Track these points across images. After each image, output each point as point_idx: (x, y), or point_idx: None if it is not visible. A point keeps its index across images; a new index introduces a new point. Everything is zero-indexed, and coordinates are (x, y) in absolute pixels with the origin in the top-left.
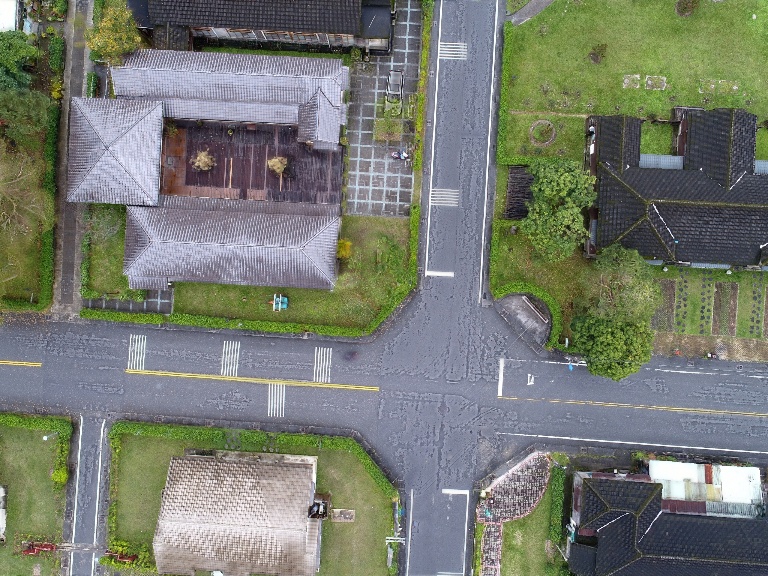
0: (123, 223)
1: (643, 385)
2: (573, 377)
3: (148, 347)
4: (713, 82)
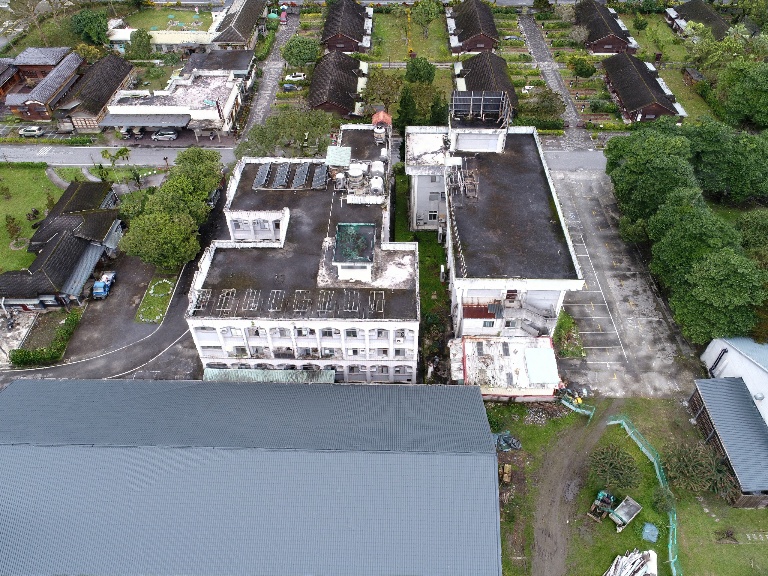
0: None
1: None
2: None
3: None
4: None
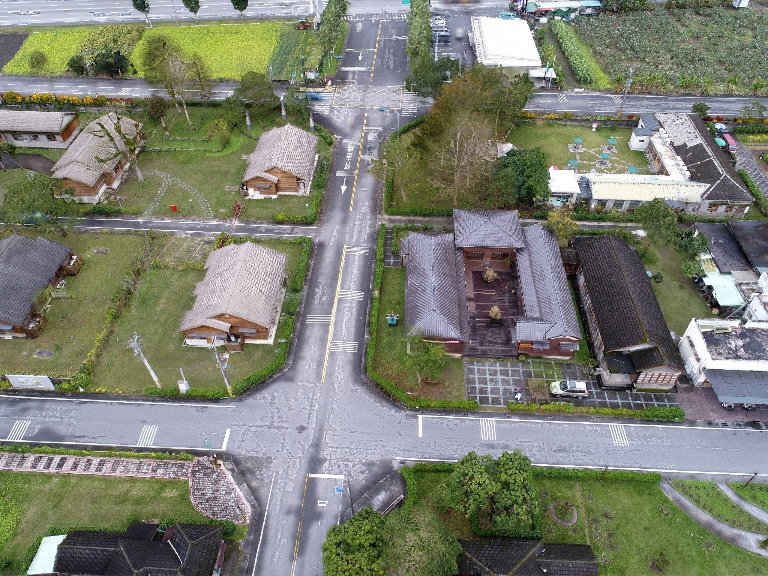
0: None
1: None
2: None
3: (361, 255)
4: None
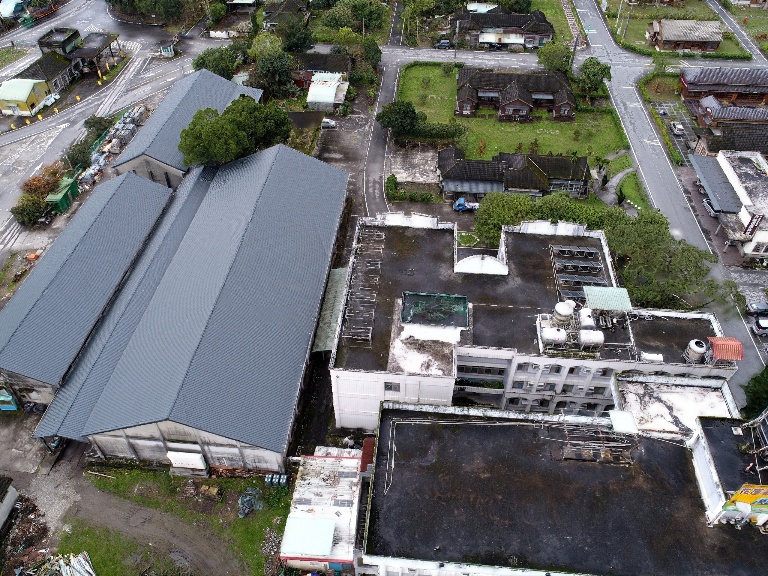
0: None
1: None
2: None
3: None
4: (513, 130)
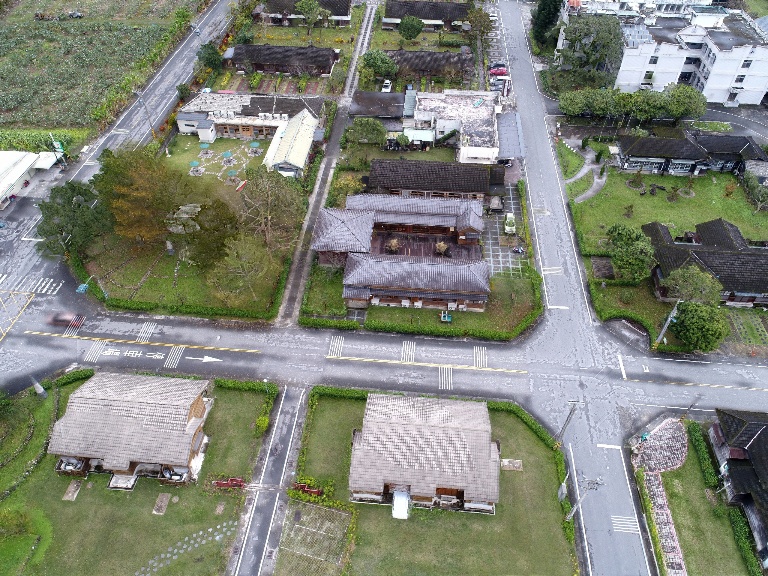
0: (342, 264)
1: (736, 374)
2: (679, 368)
3: (345, 343)
4: None
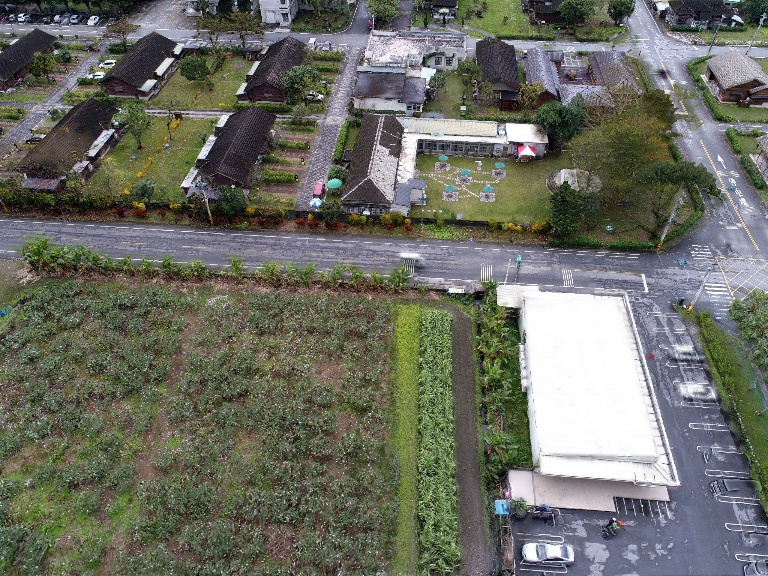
0: None
1: (630, 17)
2: None
3: None
4: None
